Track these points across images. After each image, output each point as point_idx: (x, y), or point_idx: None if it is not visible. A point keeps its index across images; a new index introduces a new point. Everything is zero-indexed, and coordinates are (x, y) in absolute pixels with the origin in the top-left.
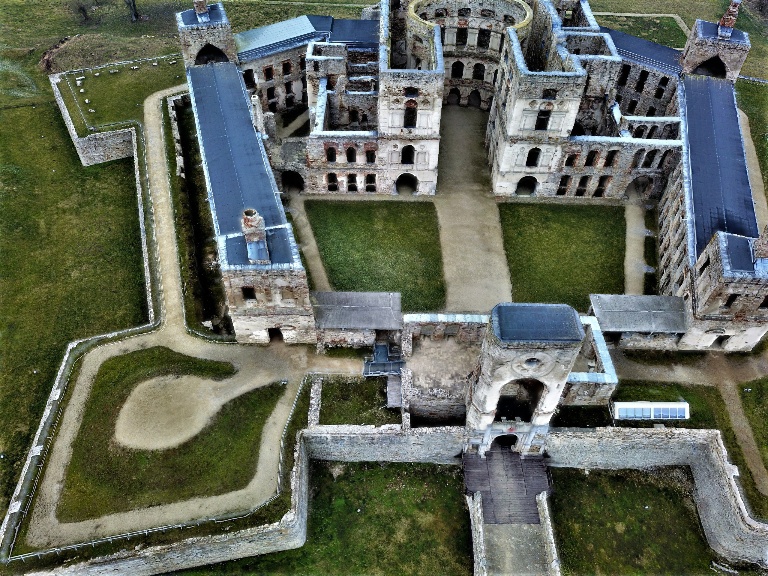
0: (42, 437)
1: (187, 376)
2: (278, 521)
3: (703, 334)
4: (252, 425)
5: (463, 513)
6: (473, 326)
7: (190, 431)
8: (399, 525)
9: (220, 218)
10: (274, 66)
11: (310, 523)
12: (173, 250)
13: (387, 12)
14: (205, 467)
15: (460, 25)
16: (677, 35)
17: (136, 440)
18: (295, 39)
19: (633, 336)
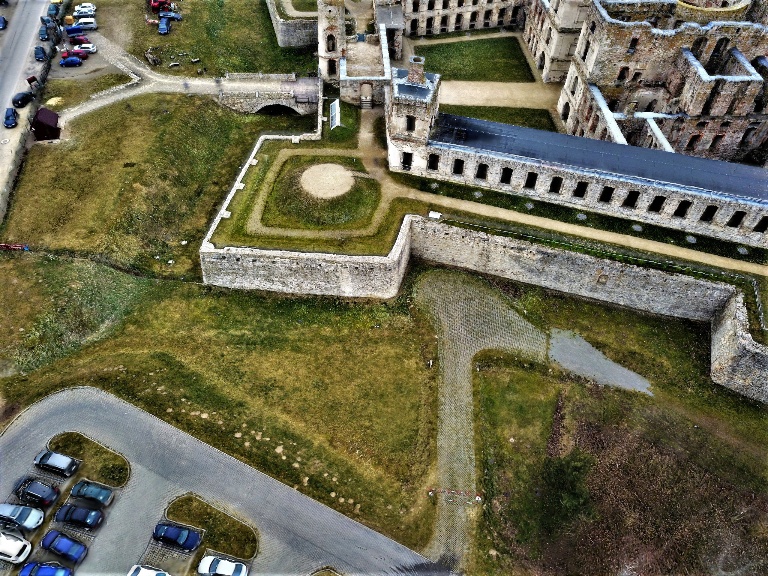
0: None
1: None
2: None
3: None
4: None
5: None
6: None
7: None
8: None
9: None
10: None
11: (290, 48)
12: None
13: None
14: None
15: None
16: None
17: None
18: None
19: None
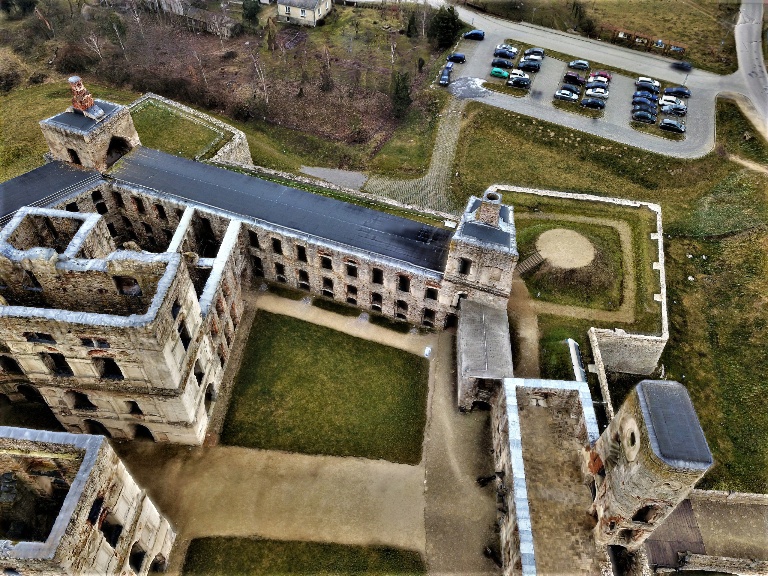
0: None
1: None
2: None
3: None
4: None
5: None
6: None
7: None
8: None
9: None
10: None
11: None
12: None
13: None
14: None
15: None
16: None
17: None
18: None
19: None
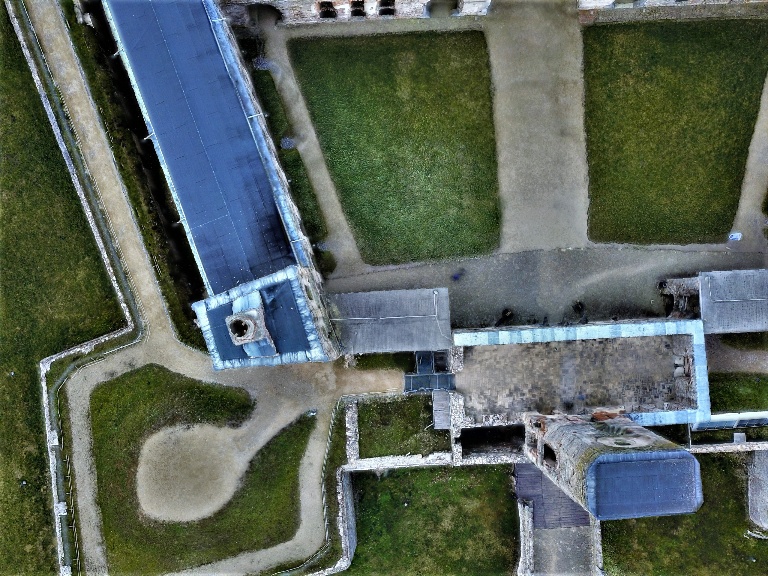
0: (61, 492)
1: (199, 425)
2: (332, 566)
3: None
4: (286, 469)
5: (510, 496)
6: None
7: (222, 497)
8: (446, 513)
9: (178, 187)
10: None
11: (359, 527)
12: (121, 194)
13: None
14: (247, 524)
15: None
16: None
17: (166, 511)
18: None
19: None
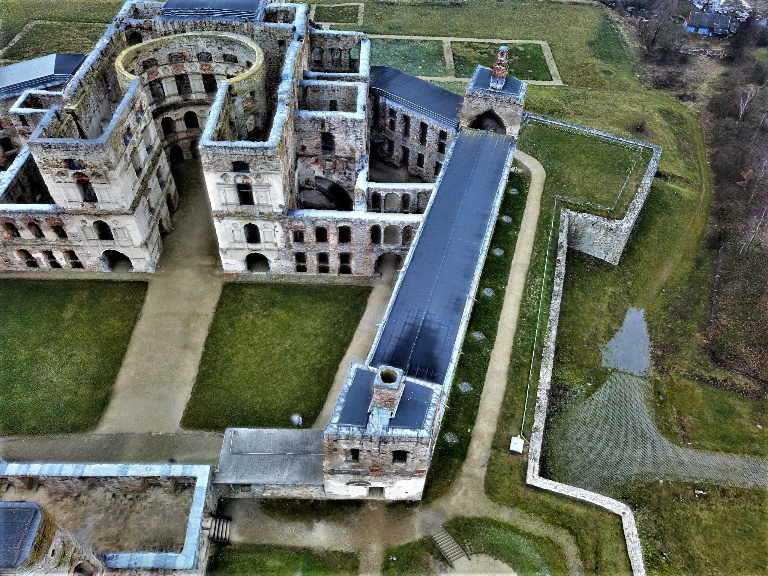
0: None
1: None
2: None
3: (346, 486)
4: None
5: None
6: (53, 479)
7: None
8: None
9: None
10: (1, 115)
11: None
12: None
13: (92, 60)
14: None
15: (204, 71)
16: (538, 65)
17: None
18: (26, 84)
19: (268, 485)
